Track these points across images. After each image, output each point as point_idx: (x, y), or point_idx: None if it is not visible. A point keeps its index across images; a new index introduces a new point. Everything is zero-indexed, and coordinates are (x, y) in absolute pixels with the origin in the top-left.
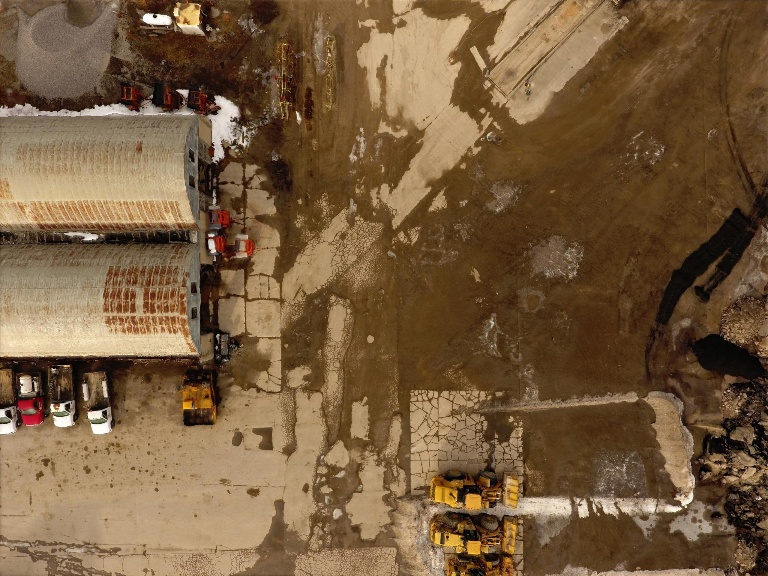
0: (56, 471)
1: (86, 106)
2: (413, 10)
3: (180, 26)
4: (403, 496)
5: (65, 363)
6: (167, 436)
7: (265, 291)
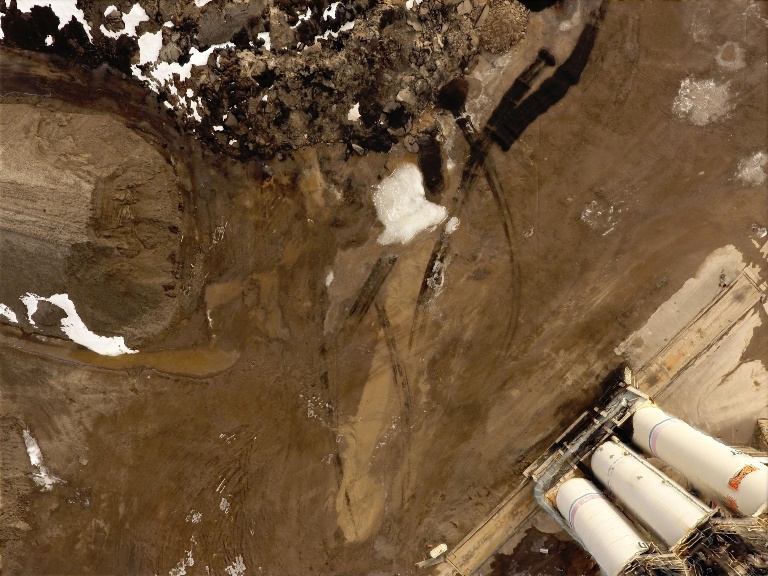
0: None
1: None
2: None
3: None
4: None
5: None
6: None
7: None
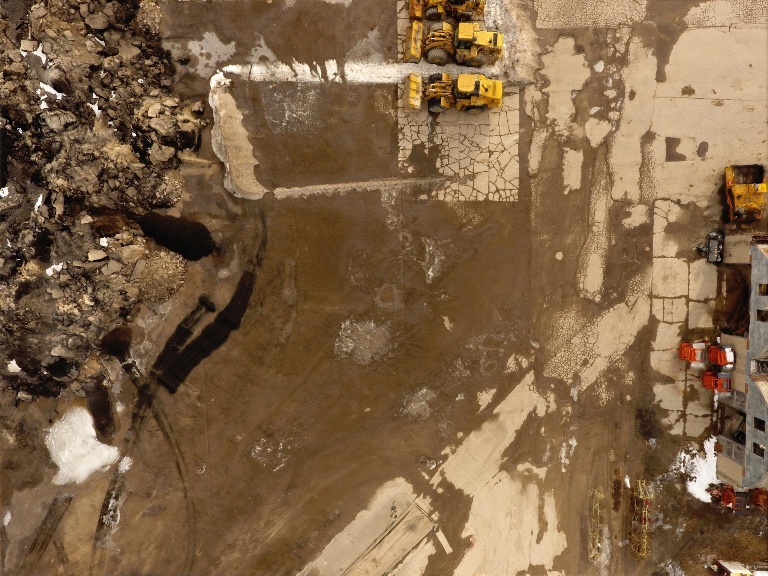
0: None
1: None
2: None
3: (748, 571)
4: (528, 86)
5: None
6: None
7: (668, 306)
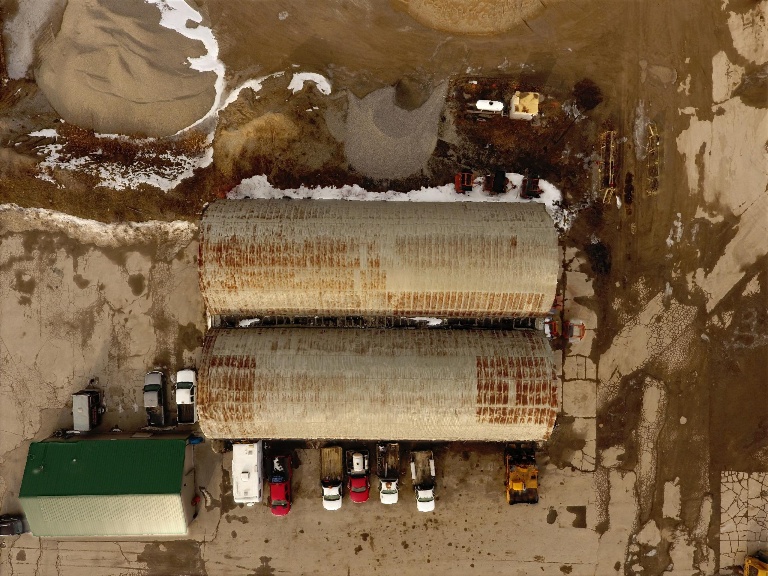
0: (375, 546)
1: (413, 188)
2: (732, 98)
3: (515, 113)
4: (712, 575)
5: (393, 441)
6: (484, 513)
7: (582, 372)
